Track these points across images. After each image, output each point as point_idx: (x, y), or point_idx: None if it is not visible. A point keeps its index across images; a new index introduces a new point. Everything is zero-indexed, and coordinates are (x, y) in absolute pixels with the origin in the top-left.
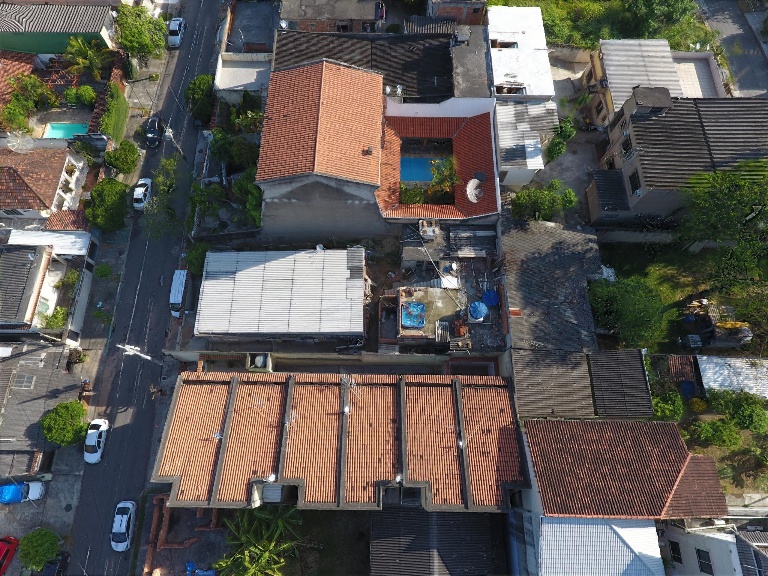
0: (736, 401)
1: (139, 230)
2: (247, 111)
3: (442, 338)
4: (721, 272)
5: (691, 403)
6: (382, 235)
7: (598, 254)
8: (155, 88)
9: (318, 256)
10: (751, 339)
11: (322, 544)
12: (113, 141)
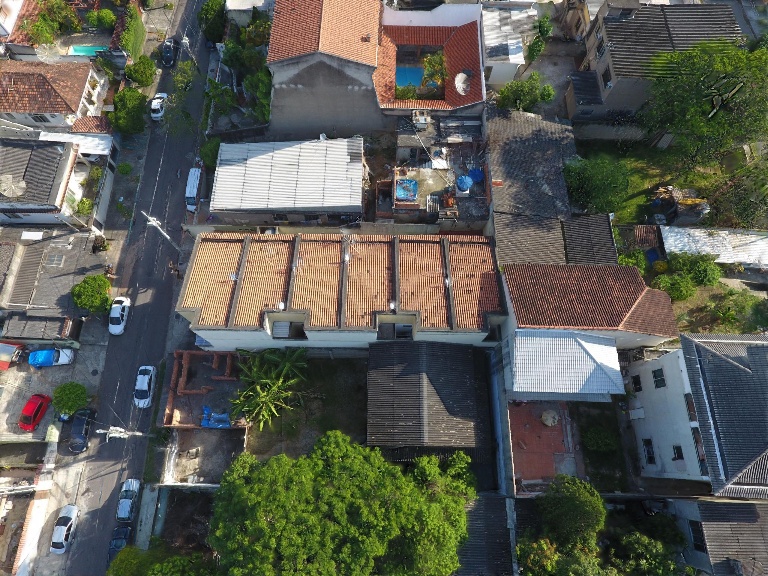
0: (693, 259)
1: (156, 138)
2: (257, 21)
3: (432, 209)
4: (687, 166)
5: (654, 264)
6: (379, 131)
7: (573, 142)
8: (170, 16)
9: (321, 145)
10: (709, 212)
11: (324, 394)
12: (132, 59)
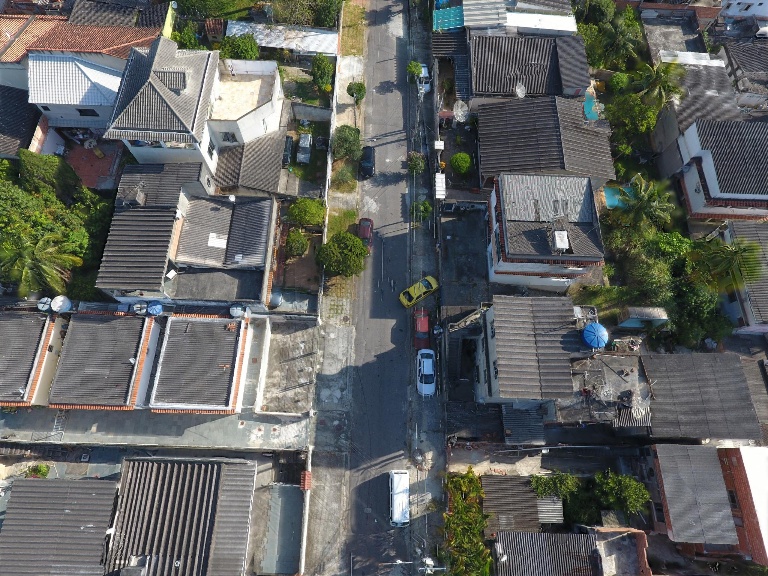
0: (235, 38)
1: None
2: None
3: (43, 3)
4: None
5: None
6: None
7: None
8: None
9: None
10: None
11: None
12: None
